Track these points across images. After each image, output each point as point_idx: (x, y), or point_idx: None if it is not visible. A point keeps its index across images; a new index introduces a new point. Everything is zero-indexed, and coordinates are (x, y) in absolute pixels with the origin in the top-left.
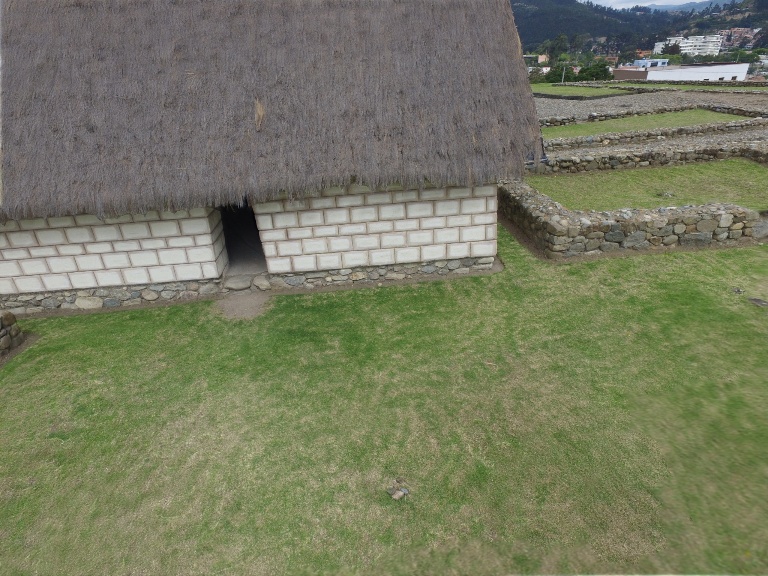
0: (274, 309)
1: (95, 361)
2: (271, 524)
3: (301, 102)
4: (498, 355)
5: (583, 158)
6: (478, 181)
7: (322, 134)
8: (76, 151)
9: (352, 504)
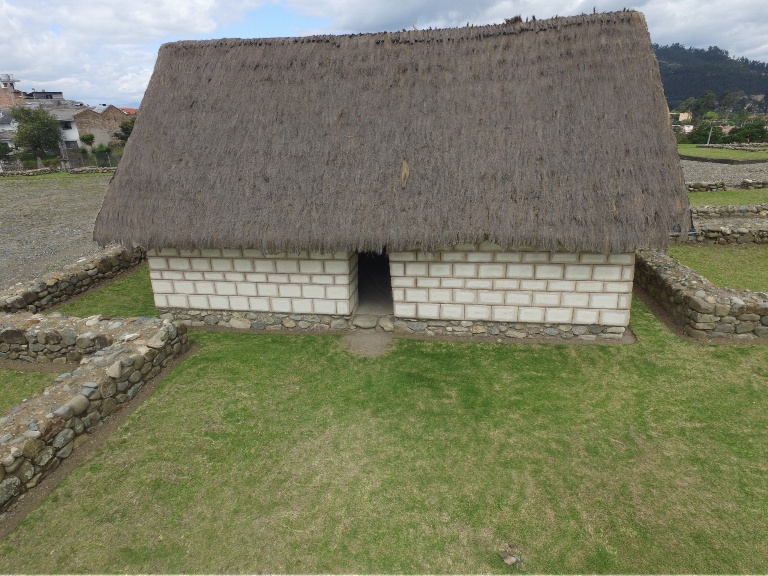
0: (396, 351)
1: (242, 376)
2: (384, 560)
3: (444, 164)
4: (625, 434)
5: (735, 230)
6: (616, 249)
7: (461, 194)
8: (253, 197)
9: (462, 559)
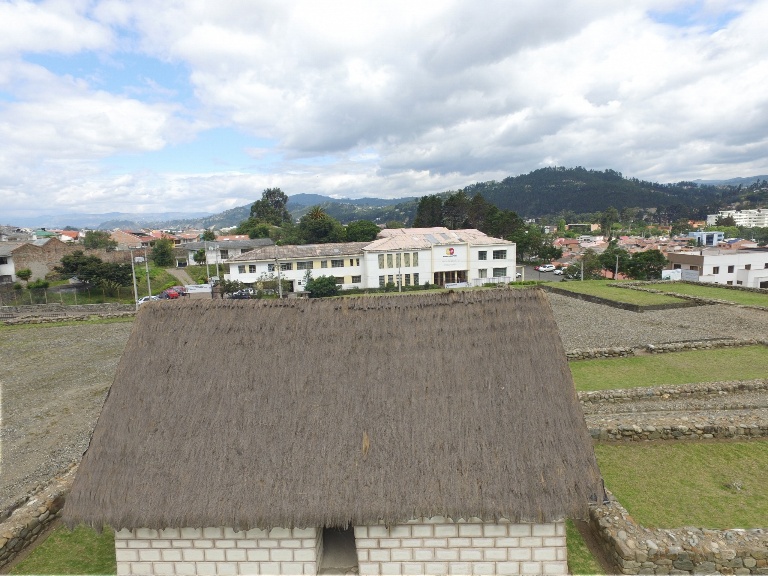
0: None
1: None
2: None
3: (399, 434)
4: None
5: (645, 428)
6: (548, 520)
7: (415, 466)
8: (227, 471)
9: None
